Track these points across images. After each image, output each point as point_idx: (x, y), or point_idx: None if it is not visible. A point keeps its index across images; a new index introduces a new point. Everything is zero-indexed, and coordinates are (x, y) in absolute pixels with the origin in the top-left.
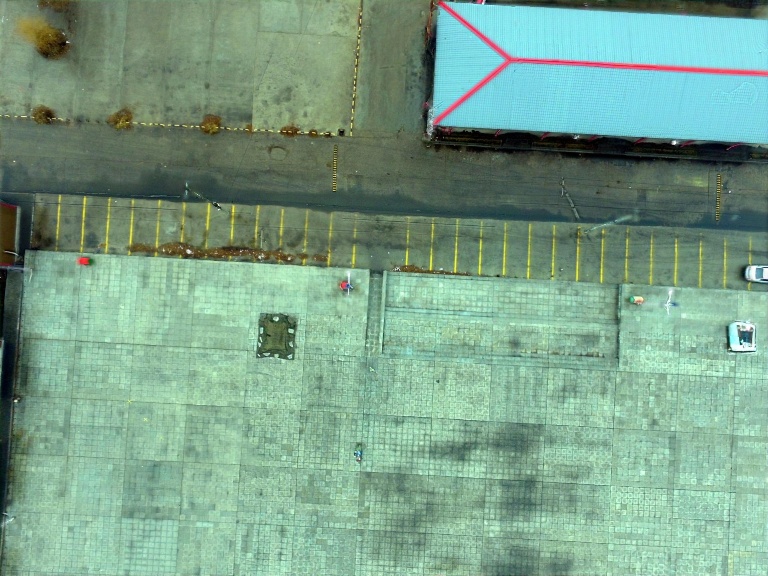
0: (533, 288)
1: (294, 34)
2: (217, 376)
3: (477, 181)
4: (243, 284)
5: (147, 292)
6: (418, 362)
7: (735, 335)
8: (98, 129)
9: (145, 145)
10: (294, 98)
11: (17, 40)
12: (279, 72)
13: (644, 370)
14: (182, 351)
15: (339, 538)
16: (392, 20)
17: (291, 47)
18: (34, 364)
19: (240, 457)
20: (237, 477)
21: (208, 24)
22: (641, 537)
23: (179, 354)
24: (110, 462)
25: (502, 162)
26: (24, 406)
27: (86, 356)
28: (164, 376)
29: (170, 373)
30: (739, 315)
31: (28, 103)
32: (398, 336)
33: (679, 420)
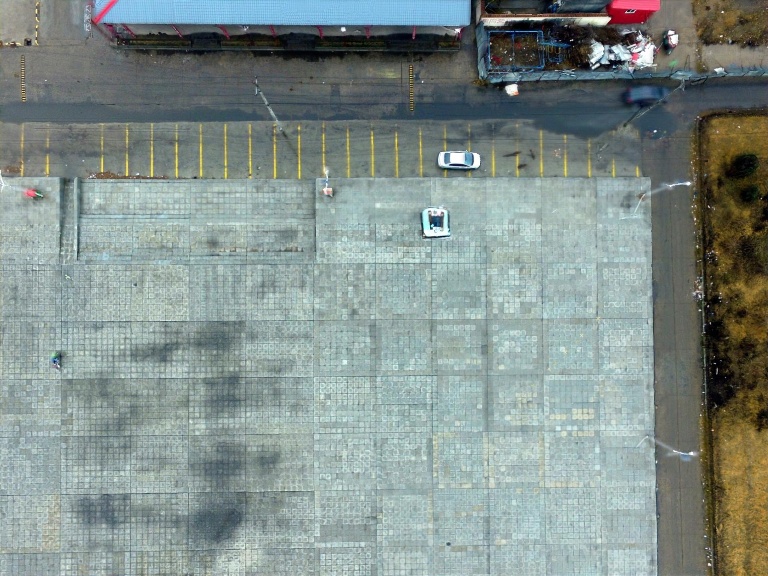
0: (230, 187)
1: None
2: None
3: (169, 84)
4: None
5: None
6: (114, 267)
7: (426, 220)
8: None
9: None
10: None
11: None
12: None
13: (341, 261)
14: None
15: (43, 446)
16: None
17: None
18: None
19: None
20: None
21: None
22: (346, 425)
23: None
24: None
25: (194, 64)
26: None
27: None
28: None
29: None
30: (433, 201)
31: None
32: (94, 243)
33: (378, 308)
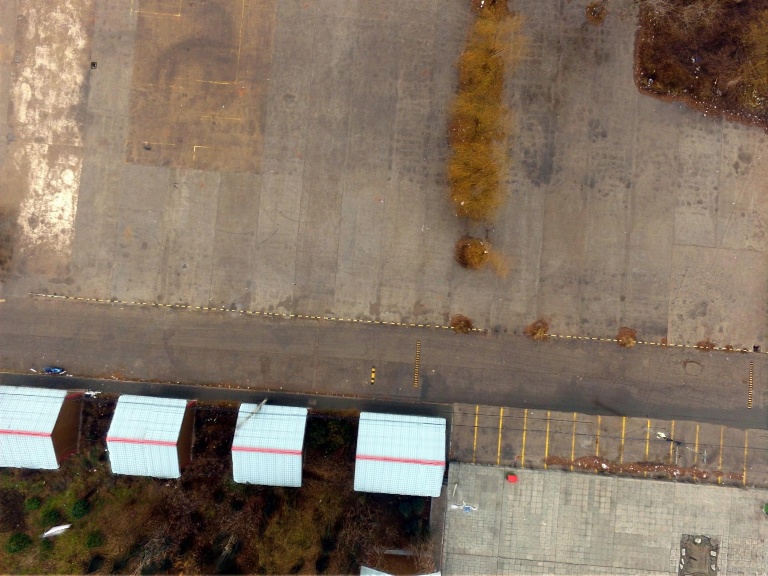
0: None
1: (709, 248)
2: None
3: None
4: (665, 504)
5: (569, 509)
6: None
7: None
8: (515, 340)
9: (561, 357)
10: (710, 313)
11: (437, 249)
12: (695, 286)
13: None
14: (603, 570)
15: None
16: None
17: (707, 261)
18: None
19: None
20: None
21: (624, 236)
22: None
23: (600, 573)
24: None
25: None
26: None
27: (508, 573)
28: None
29: None
30: None
31: (447, 312)
32: None
33: None
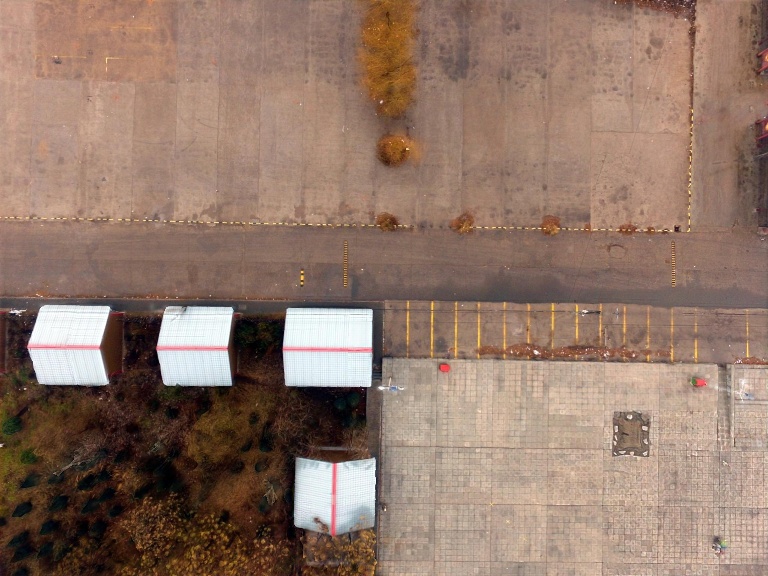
0: None
1: (627, 133)
2: (575, 476)
3: None
4: (596, 384)
5: (503, 395)
6: None
7: None
8: (441, 234)
9: (488, 248)
10: (630, 196)
11: (359, 149)
12: (615, 171)
13: None
14: (540, 452)
15: None
16: (722, 116)
17: (625, 146)
18: (397, 471)
19: (601, 555)
20: (600, 575)
21: (542, 126)
22: None
23: (537, 455)
24: (476, 565)
25: None
26: (389, 513)
27: (447, 461)
28: (524, 478)
29: (529, 475)
30: None
31: (372, 211)
32: (747, 428)
33: None
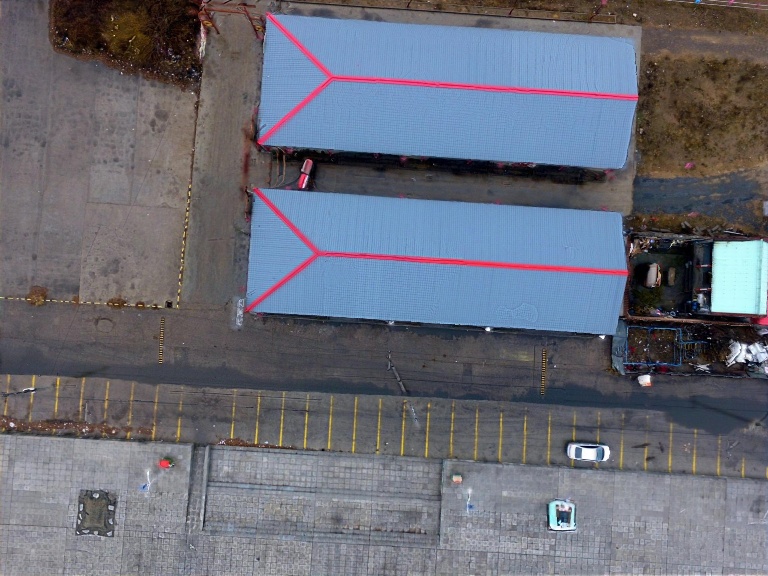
0: (357, 463)
1: (123, 205)
2: (35, 553)
3: (304, 354)
4: (64, 460)
5: None
6: (239, 539)
7: (554, 515)
8: None
9: None
10: (122, 270)
11: None
12: (107, 244)
13: (465, 548)
14: (0, 528)
15: None
16: (221, 192)
17: (120, 218)
18: None
19: None
20: None
21: (37, 195)
22: None
23: None
24: None
25: (329, 335)
26: None
27: None
28: None
29: None
30: (560, 493)
31: None
32: (220, 512)
33: None
